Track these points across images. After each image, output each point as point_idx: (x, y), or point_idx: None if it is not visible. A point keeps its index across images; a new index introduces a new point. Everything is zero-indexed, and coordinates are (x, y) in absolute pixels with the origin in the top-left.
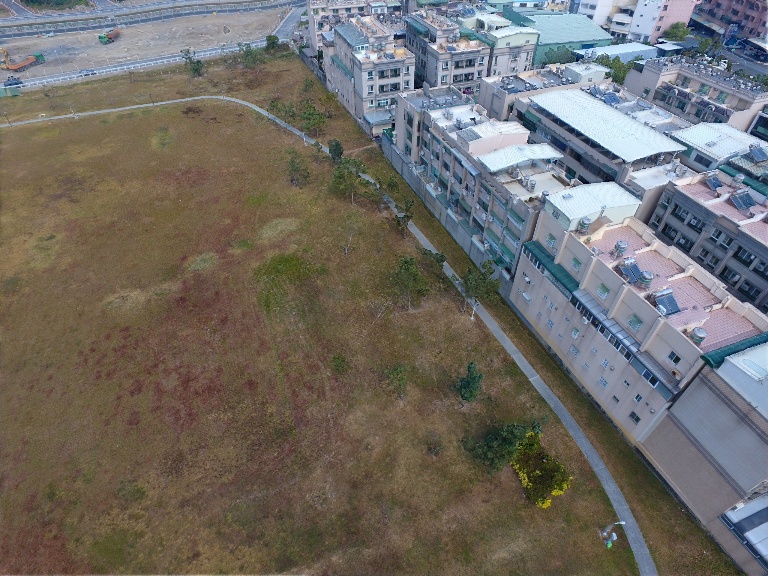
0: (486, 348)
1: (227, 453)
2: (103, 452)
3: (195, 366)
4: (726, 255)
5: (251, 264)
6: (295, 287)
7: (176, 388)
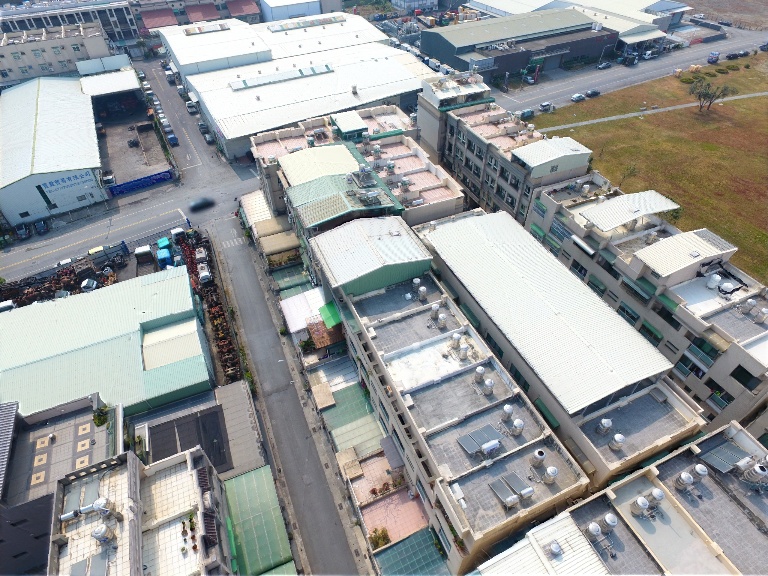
0: None
1: (697, 170)
2: (762, 168)
3: None
4: None
5: None
6: (765, 253)
7: (764, 191)
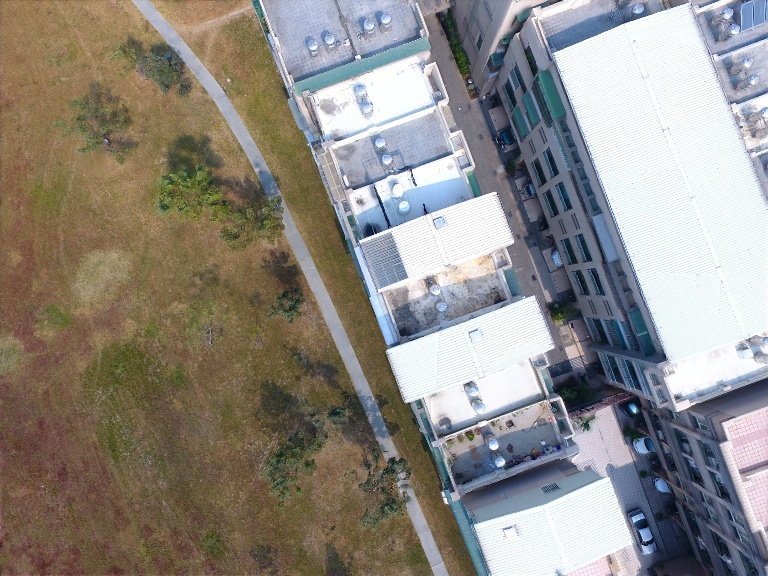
0: (389, 523)
1: None
2: None
3: (46, 545)
4: (731, 542)
5: (75, 365)
6: (145, 414)
7: None
